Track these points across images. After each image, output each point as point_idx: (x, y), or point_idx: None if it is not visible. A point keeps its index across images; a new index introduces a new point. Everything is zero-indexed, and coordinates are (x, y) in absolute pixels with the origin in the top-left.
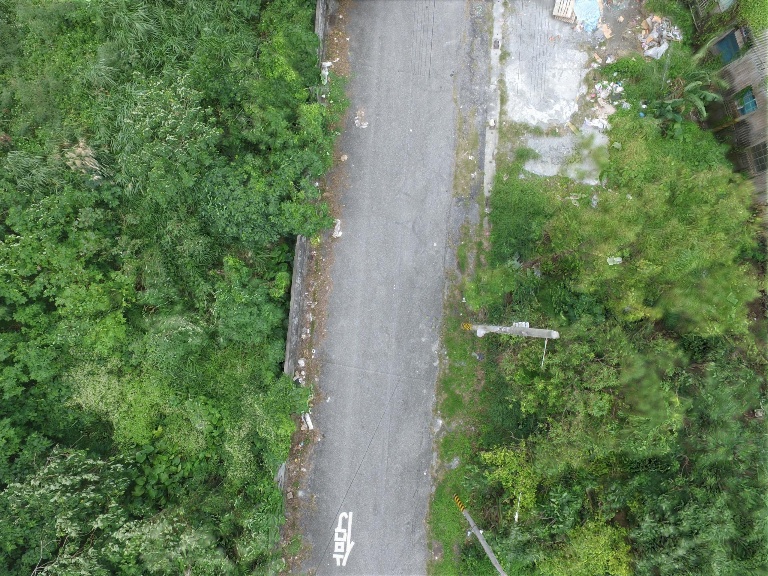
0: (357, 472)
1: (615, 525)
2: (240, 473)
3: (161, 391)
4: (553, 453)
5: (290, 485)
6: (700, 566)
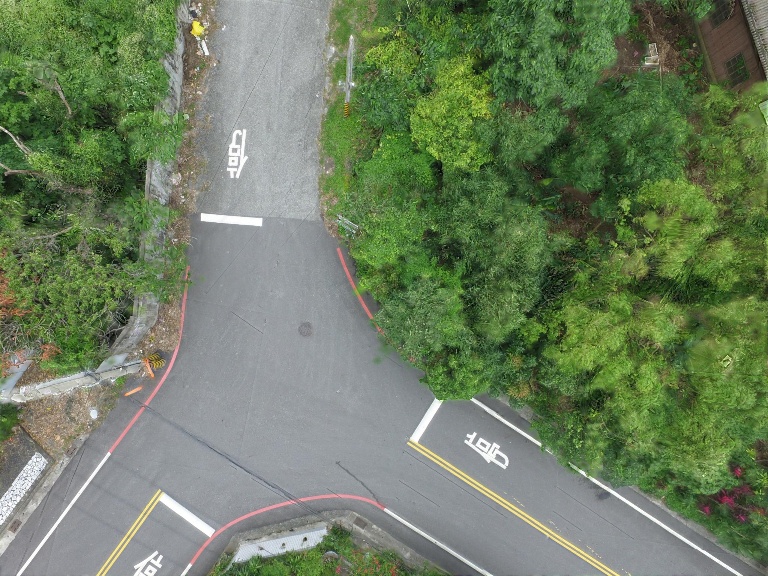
0: (251, 93)
1: (479, 71)
2: (130, 70)
3: (56, 6)
4: (427, 25)
5: (186, 108)
6: (546, 63)
